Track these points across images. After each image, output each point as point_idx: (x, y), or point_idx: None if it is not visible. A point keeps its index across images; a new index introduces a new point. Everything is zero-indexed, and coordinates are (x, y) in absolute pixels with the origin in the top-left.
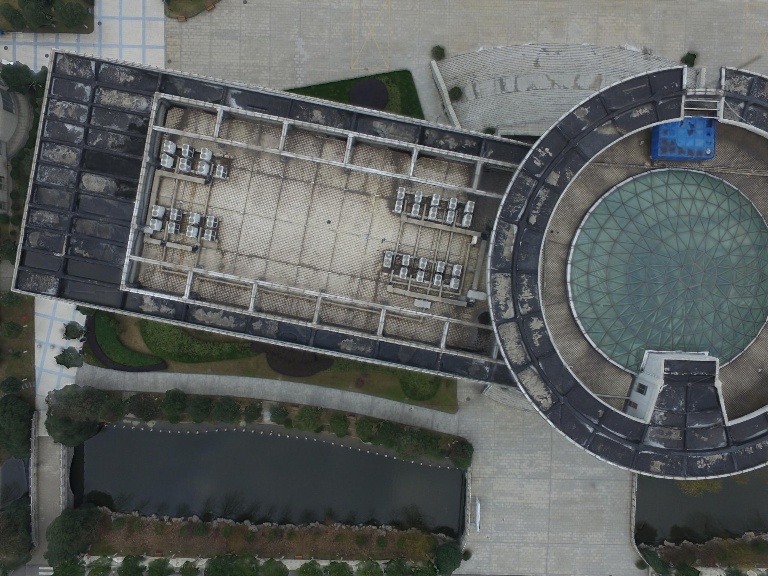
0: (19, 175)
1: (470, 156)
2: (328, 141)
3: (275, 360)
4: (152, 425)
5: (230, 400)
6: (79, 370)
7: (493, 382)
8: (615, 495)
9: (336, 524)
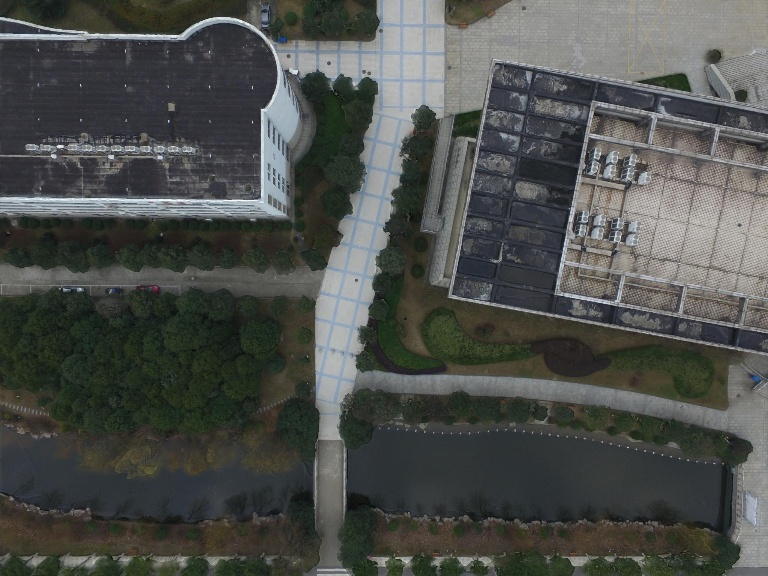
0: (303, 182)
1: None
2: (739, 146)
3: (555, 361)
4: (424, 427)
5: (521, 401)
6: (358, 374)
7: None
8: None
9: (604, 521)
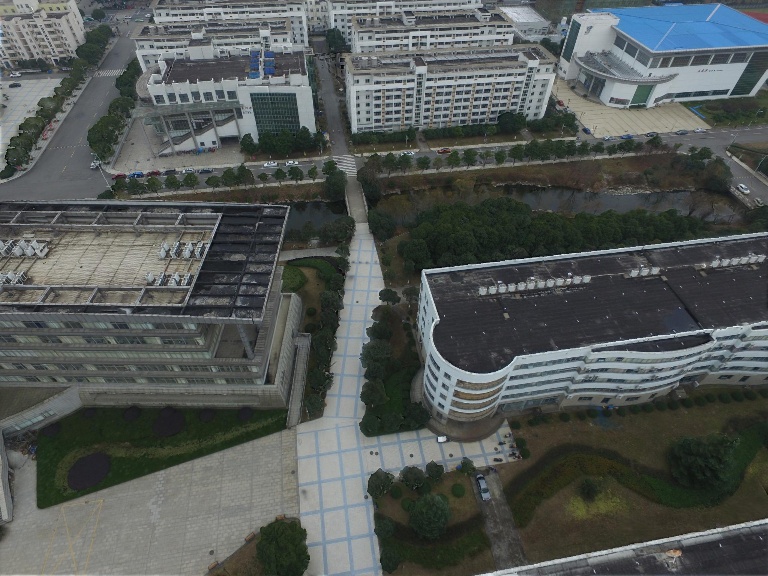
0: None
1: None
2: None
3: None
4: None
5: None
6: None
7: None
8: None
9: None
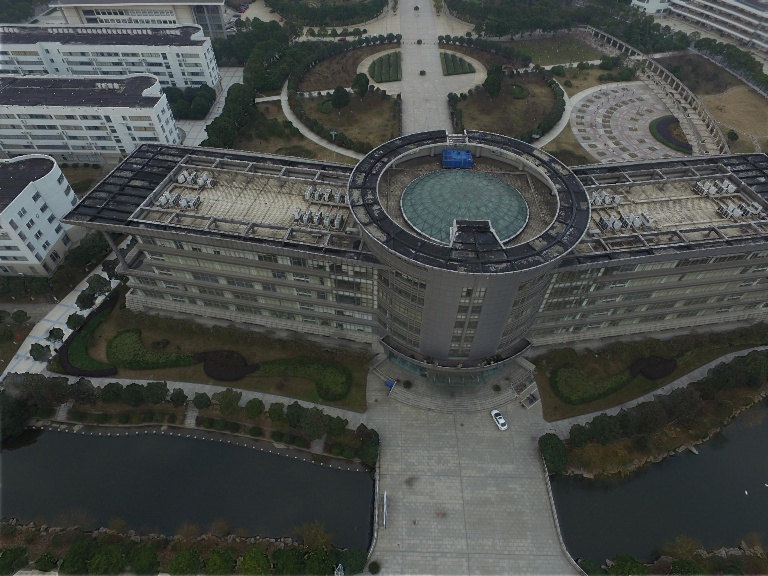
0: None
1: (349, 174)
2: None
3: (211, 364)
4: (77, 429)
5: None
6: None
7: (358, 260)
8: (531, 494)
9: (230, 536)
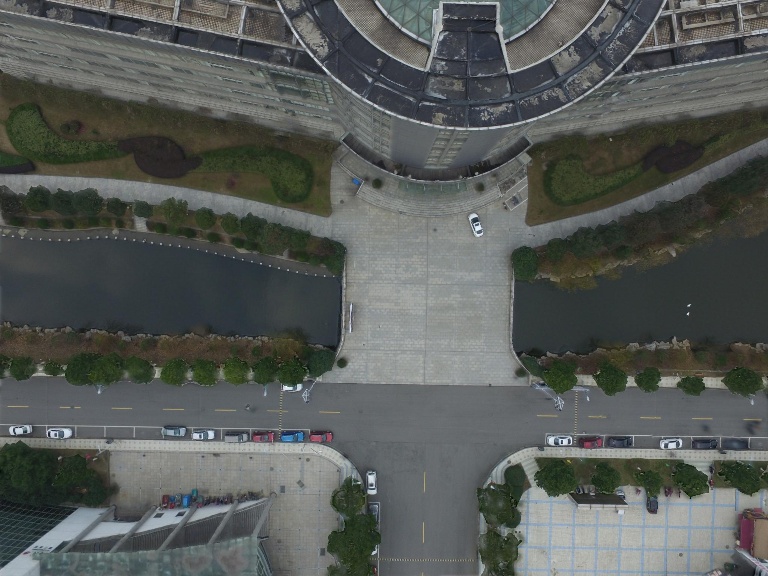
0: None
1: None
2: None
3: (142, 158)
4: (23, 233)
5: None
6: None
7: None
8: (493, 301)
9: (211, 335)
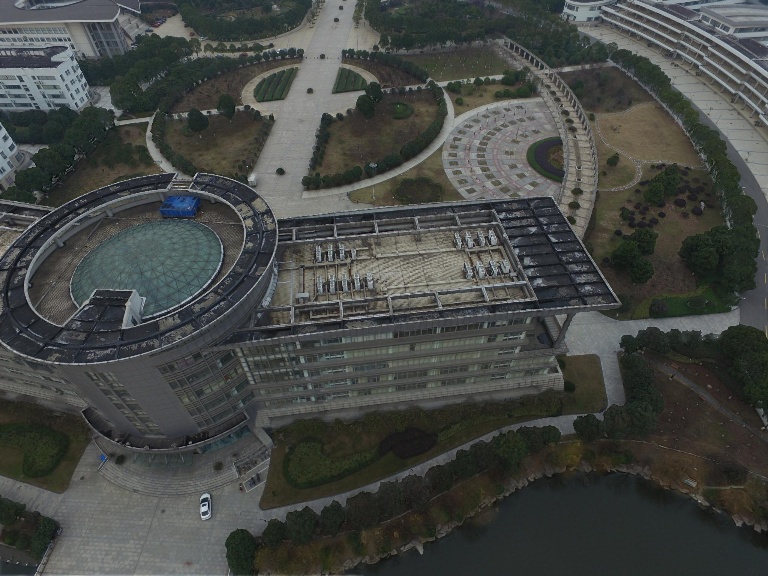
0: None
1: None
2: None
3: None
4: None
5: None
6: None
7: None
8: None
9: None
